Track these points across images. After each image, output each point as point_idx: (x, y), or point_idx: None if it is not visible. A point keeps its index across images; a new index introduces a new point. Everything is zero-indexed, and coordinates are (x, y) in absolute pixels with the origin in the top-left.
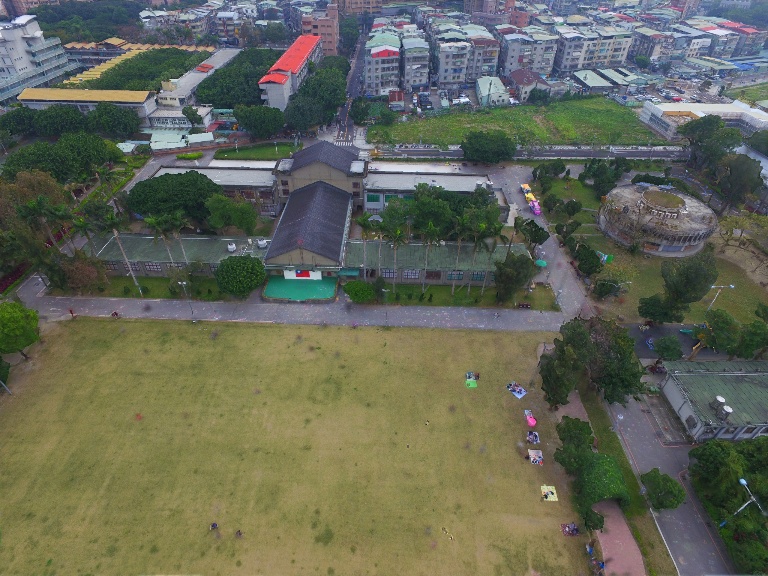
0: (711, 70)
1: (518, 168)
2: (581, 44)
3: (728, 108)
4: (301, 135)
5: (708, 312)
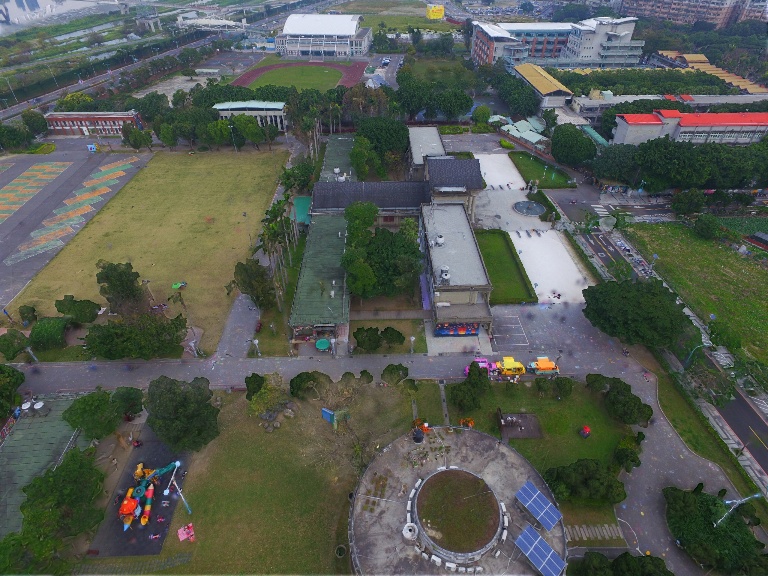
0: None
1: (641, 375)
2: None
3: None
4: (597, 182)
5: (106, 393)
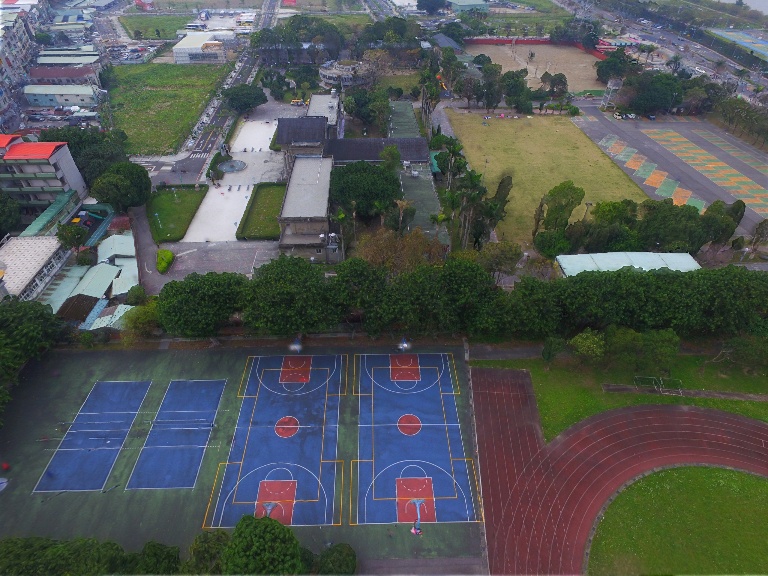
0: (86, 30)
1: None
2: (13, 33)
3: (198, 37)
4: None
5: (456, 64)
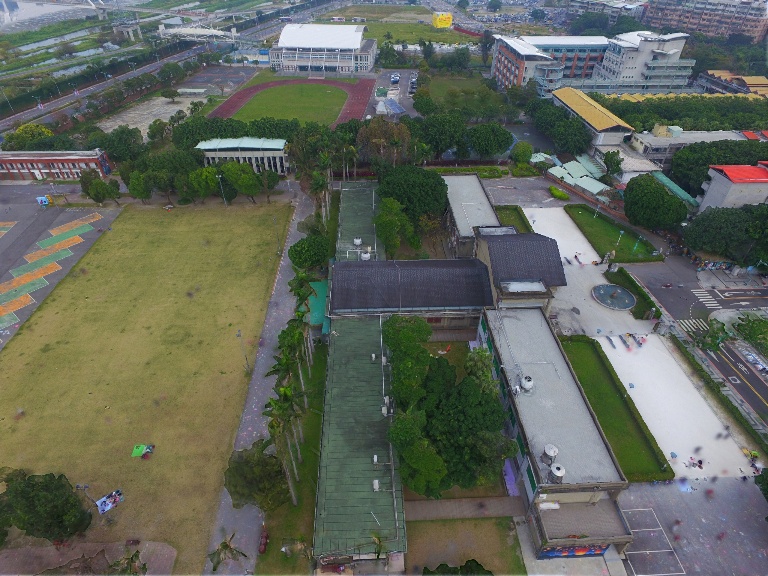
0: None
1: None
2: None
3: None
4: (688, 253)
5: None
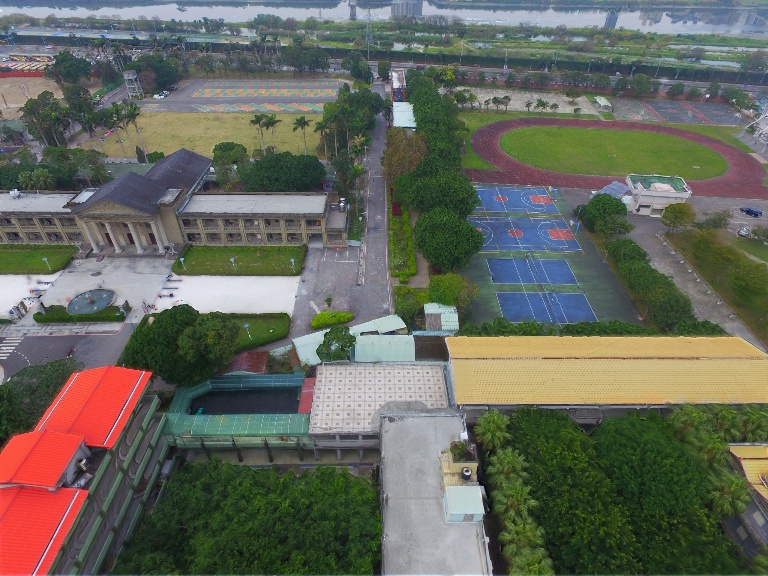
0: None
1: None
2: None
3: None
4: None
5: None
